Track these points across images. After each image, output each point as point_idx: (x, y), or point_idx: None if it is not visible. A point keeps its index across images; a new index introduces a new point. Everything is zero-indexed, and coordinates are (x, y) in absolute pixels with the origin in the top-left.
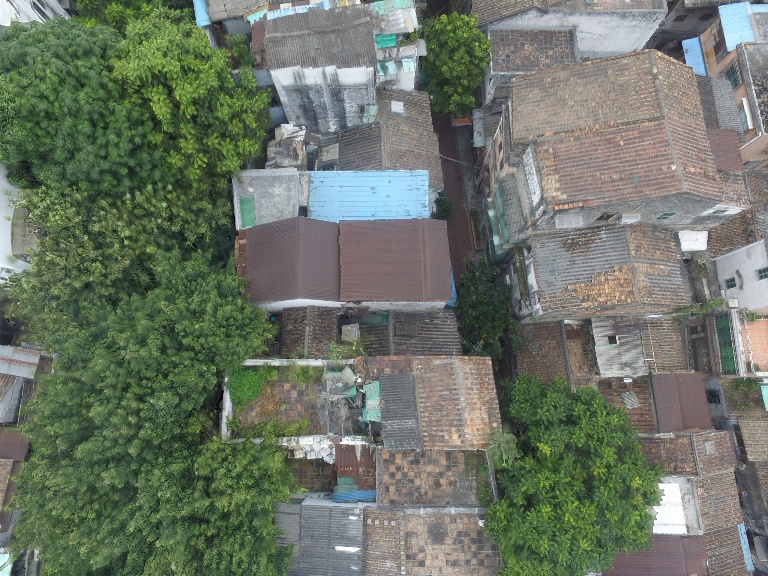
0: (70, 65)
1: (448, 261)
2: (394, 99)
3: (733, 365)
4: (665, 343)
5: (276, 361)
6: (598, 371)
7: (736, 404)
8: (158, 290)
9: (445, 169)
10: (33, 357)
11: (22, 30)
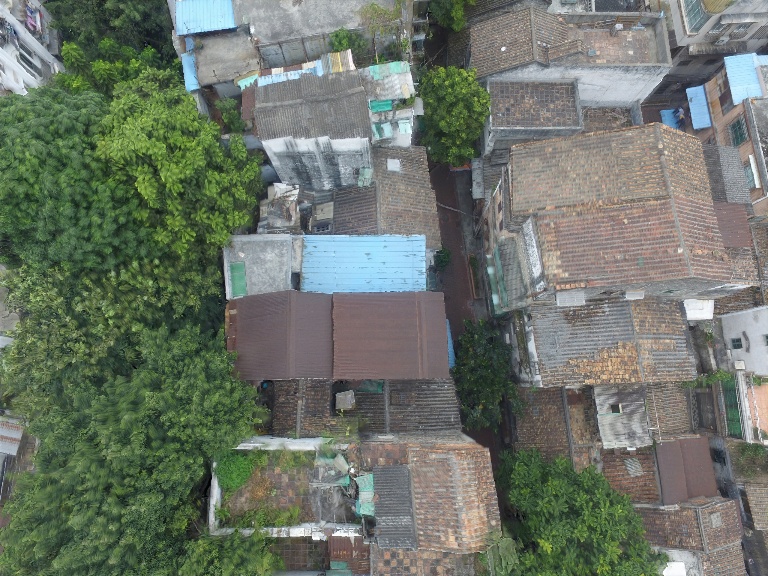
0: (51, 145)
1: (445, 336)
2: (390, 156)
3: (739, 429)
4: (669, 405)
5: (266, 445)
6: (600, 438)
7: (742, 469)
8: (143, 373)
9: (443, 214)
10: (16, 432)
11: (2, 105)
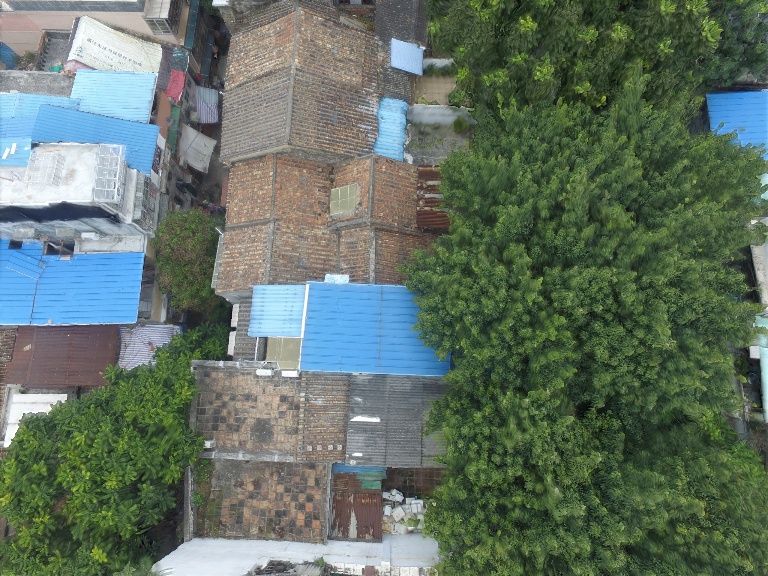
0: None
1: None
2: None
3: None
4: None
5: None
6: None
7: None
8: None
9: None
10: None
11: None
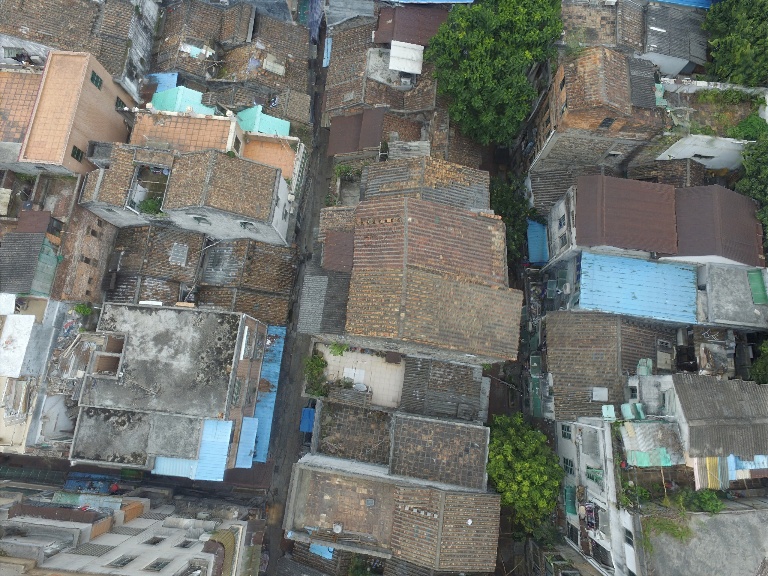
0: None
1: (577, 209)
2: (601, 407)
3: None
4: None
5: (730, 141)
6: None
7: (307, 132)
8: None
9: (494, 393)
10: None
11: None
